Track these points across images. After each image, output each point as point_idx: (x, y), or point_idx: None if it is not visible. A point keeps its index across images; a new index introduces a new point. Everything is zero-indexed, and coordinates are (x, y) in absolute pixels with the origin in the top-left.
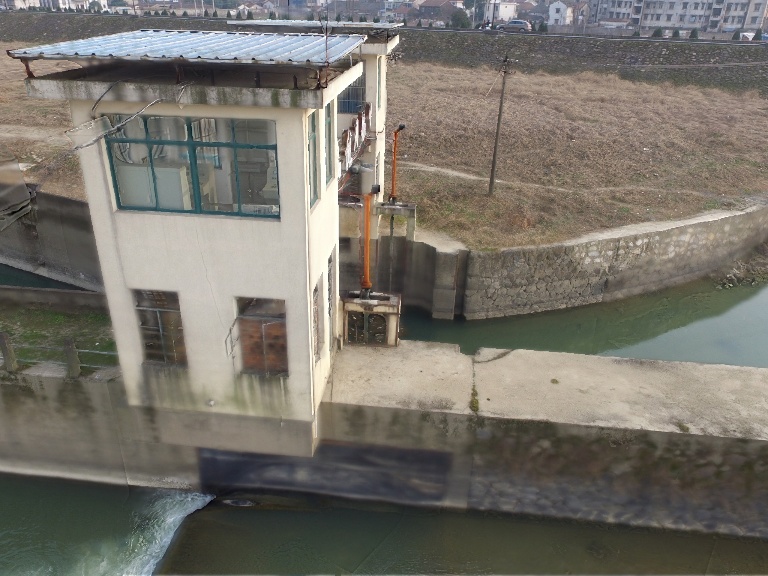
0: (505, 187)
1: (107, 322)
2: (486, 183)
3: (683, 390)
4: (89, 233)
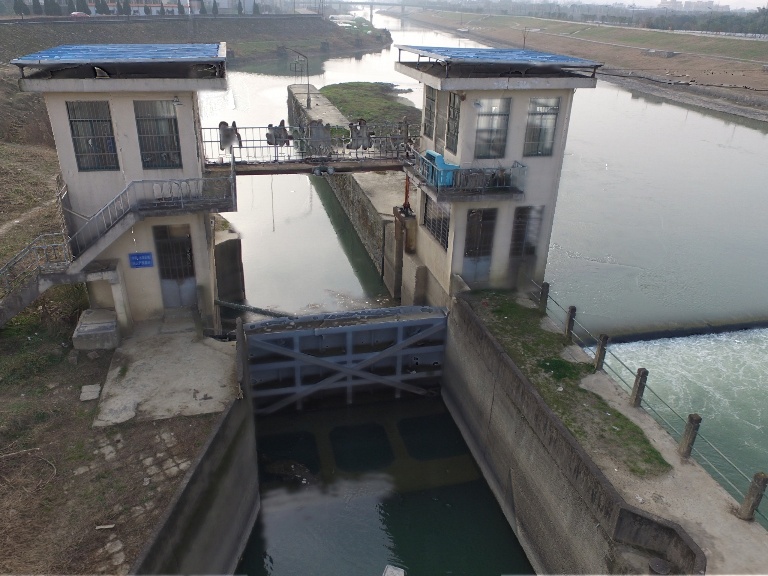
0: (46, 218)
1: None
2: (27, 225)
3: (388, 188)
4: (213, 506)
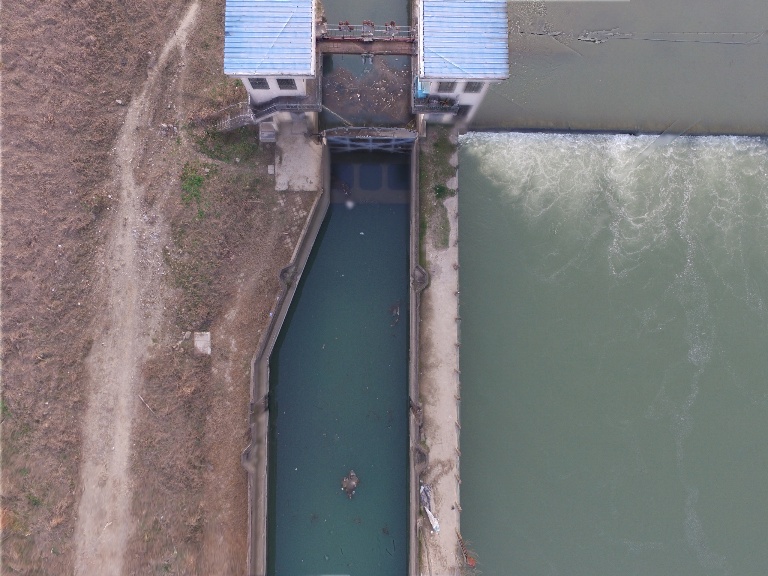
0: None
1: (423, 155)
2: None
3: None
4: None
